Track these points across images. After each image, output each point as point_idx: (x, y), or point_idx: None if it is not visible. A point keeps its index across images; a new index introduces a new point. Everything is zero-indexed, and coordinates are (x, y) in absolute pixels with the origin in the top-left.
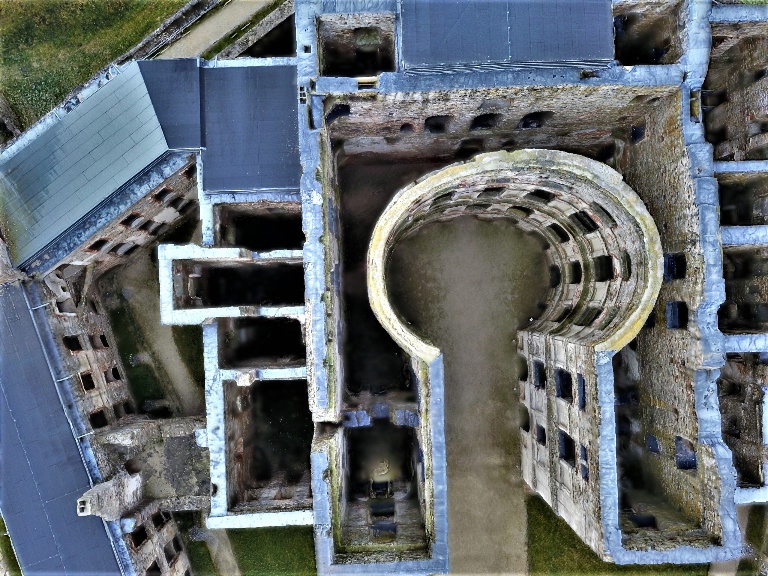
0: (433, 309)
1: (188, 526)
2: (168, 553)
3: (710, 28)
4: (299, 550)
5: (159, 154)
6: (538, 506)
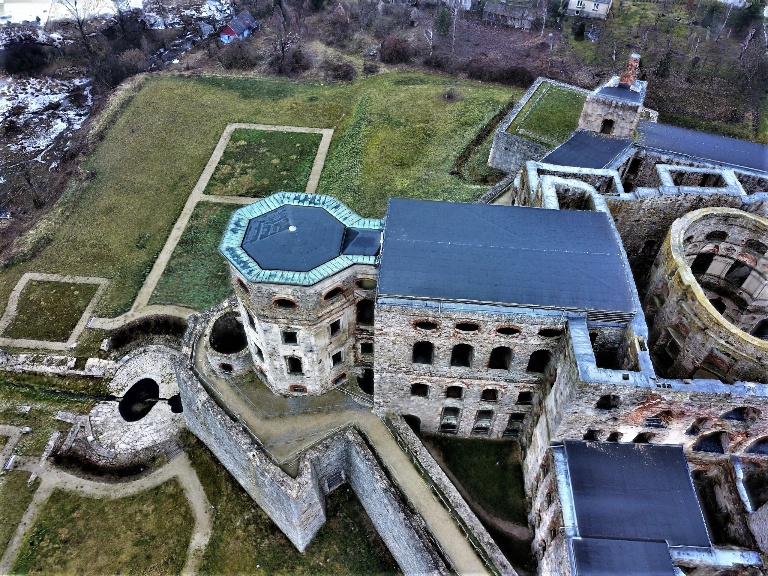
0: None
1: None
2: None
3: (570, 179)
4: None
5: None
6: None
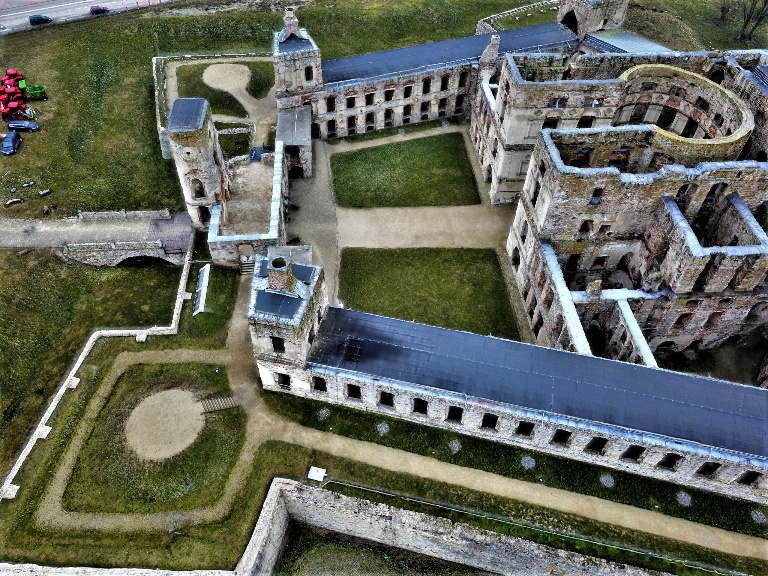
0: None
1: (449, 121)
2: (440, 108)
3: None
4: (443, 156)
5: None
6: (489, 254)
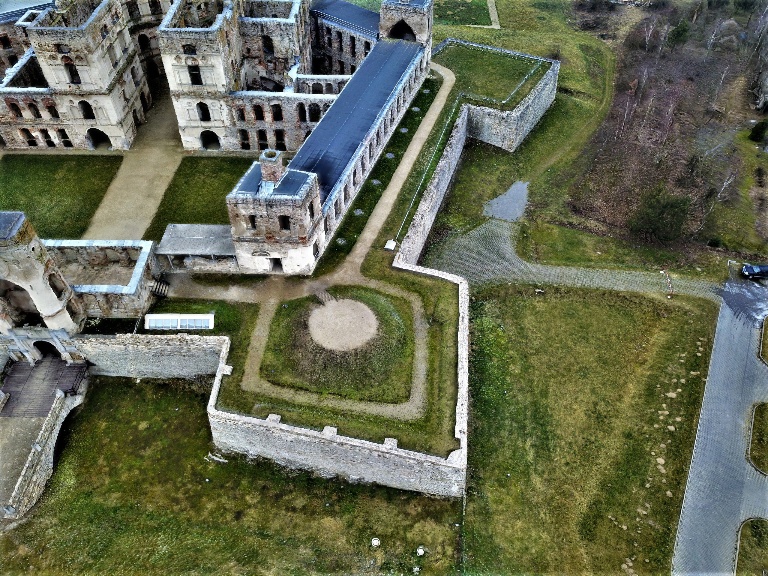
0: (163, 97)
1: None
2: None
3: None
4: (37, 169)
5: (47, 3)
6: (189, 160)
